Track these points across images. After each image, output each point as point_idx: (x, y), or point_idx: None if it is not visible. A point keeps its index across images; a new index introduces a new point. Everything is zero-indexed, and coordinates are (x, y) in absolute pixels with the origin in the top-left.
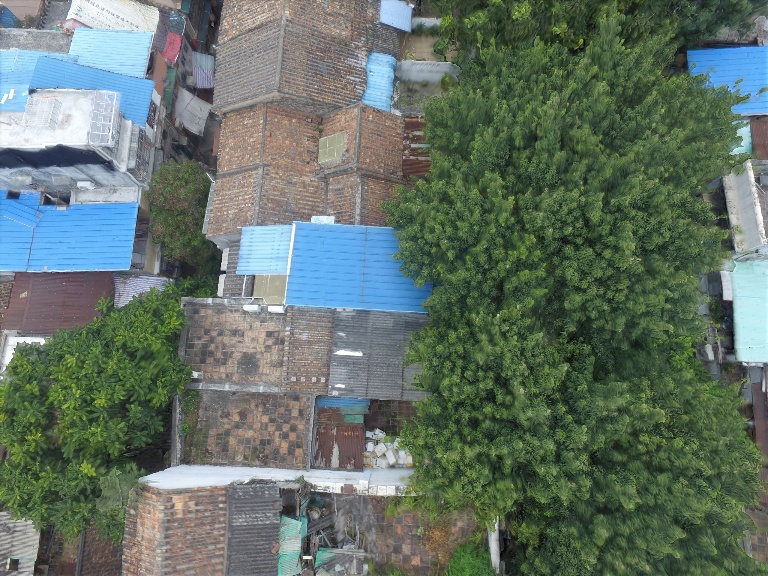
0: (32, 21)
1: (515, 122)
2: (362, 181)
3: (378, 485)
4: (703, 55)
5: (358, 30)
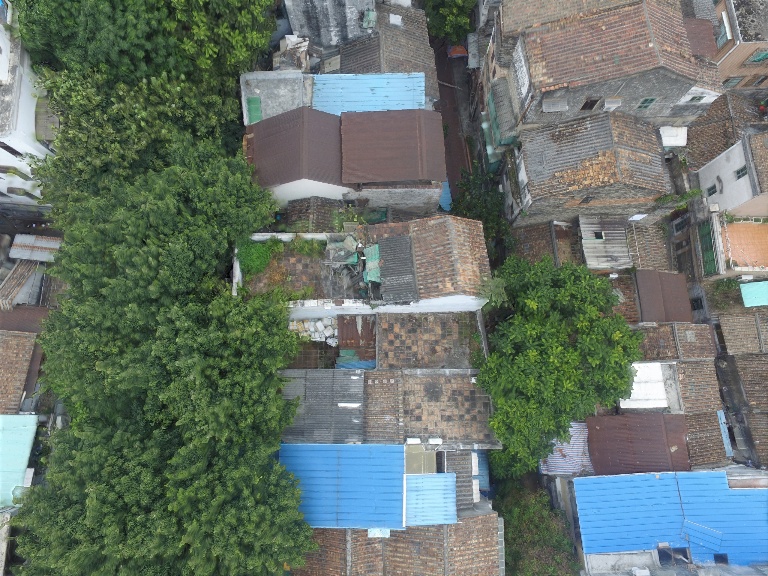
0: None
1: None
2: None
3: None
4: None
5: None
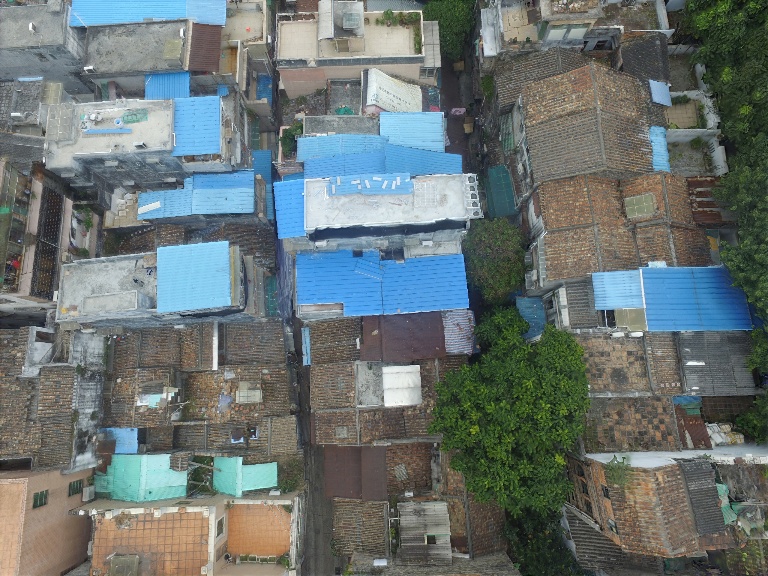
0: (305, 101)
1: None
2: (671, 231)
3: (760, 456)
4: None
5: (640, 110)
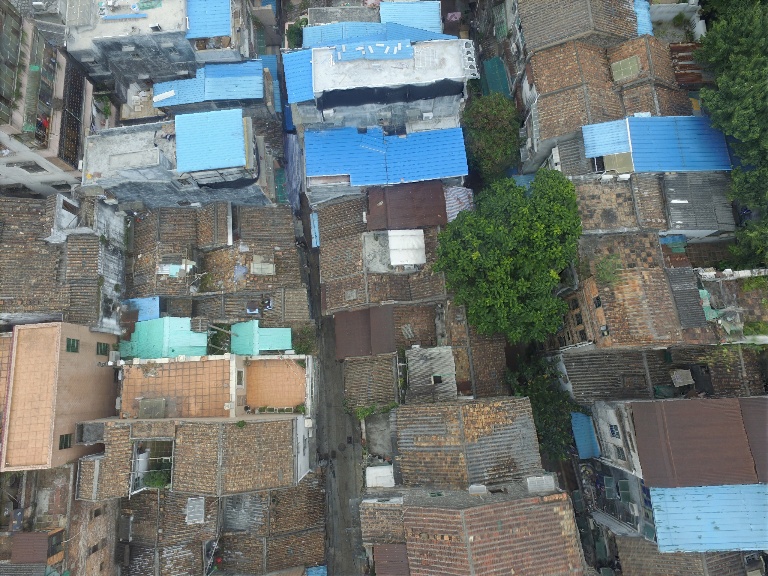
0: (308, 4)
1: None
2: (655, 89)
3: (739, 271)
4: None
5: None
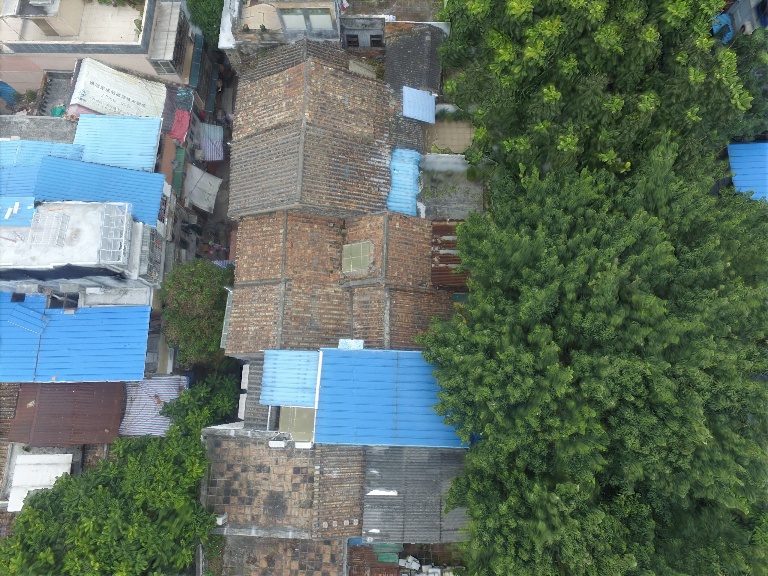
0: (33, 96)
1: (566, 272)
2: (390, 295)
3: None
4: (745, 150)
5: (381, 126)
